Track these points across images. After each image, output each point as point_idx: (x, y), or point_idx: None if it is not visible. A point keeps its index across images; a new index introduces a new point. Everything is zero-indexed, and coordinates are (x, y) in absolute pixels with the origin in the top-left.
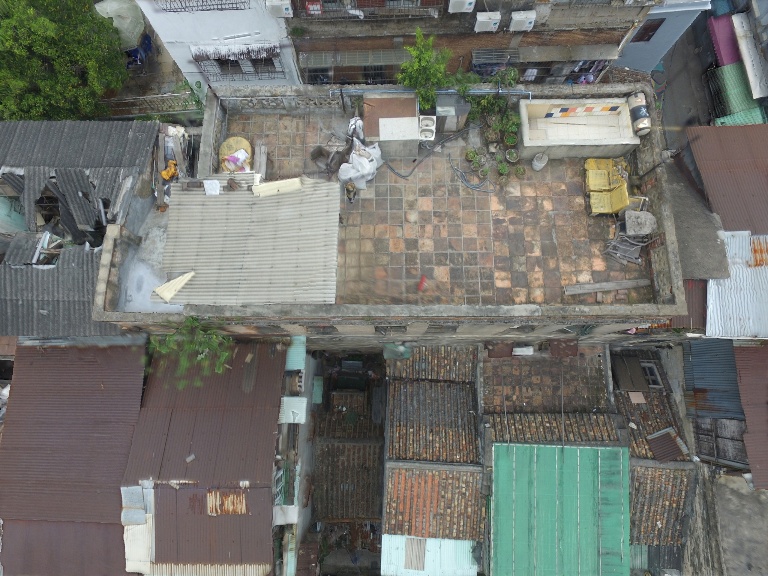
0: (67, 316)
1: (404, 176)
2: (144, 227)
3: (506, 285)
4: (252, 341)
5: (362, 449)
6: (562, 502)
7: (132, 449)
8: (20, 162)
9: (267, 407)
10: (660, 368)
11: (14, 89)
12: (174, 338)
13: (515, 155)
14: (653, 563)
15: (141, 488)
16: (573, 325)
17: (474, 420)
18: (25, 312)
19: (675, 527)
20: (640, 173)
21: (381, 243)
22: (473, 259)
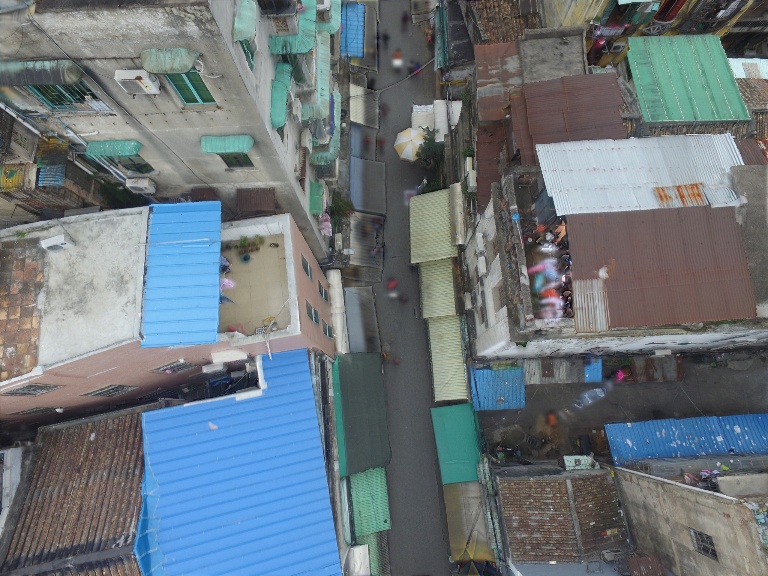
0: None
1: None
2: None
3: None
4: None
5: None
6: (686, 89)
7: None
8: None
9: None
10: None
11: None
12: None
13: None
14: None
15: None
16: None
17: None
18: None
19: None
20: None
21: None
22: None
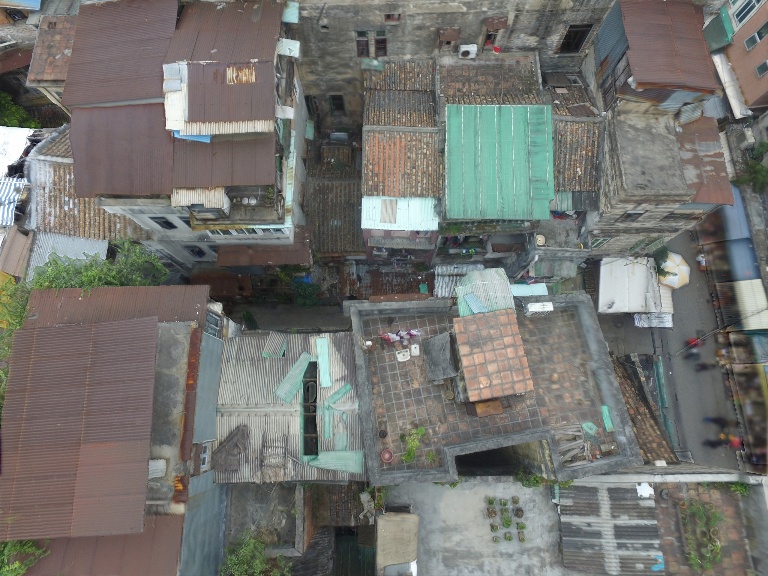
0: None
1: None
2: None
3: None
4: None
5: (348, 187)
6: (500, 145)
7: (170, 47)
8: None
9: (270, 27)
10: (581, 78)
11: None
12: None
13: None
14: (577, 206)
15: (178, 65)
16: None
17: (433, 107)
18: None
19: (592, 174)
20: None
21: None
22: None
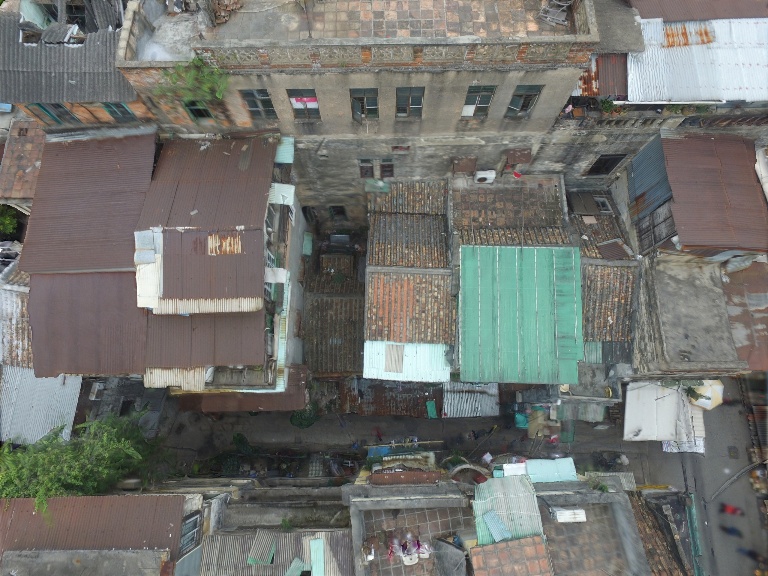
0: (92, 85)
1: None
2: (157, 22)
3: None
4: (247, 138)
5: (349, 303)
6: (522, 294)
7: (144, 207)
8: None
9: (260, 178)
10: (611, 201)
11: None
12: (183, 66)
13: None
14: (607, 358)
15: (152, 232)
16: (517, 96)
17: (445, 239)
18: (57, 82)
19: (625, 323)
20: None
21: (354, 14)
22: (429, 24)
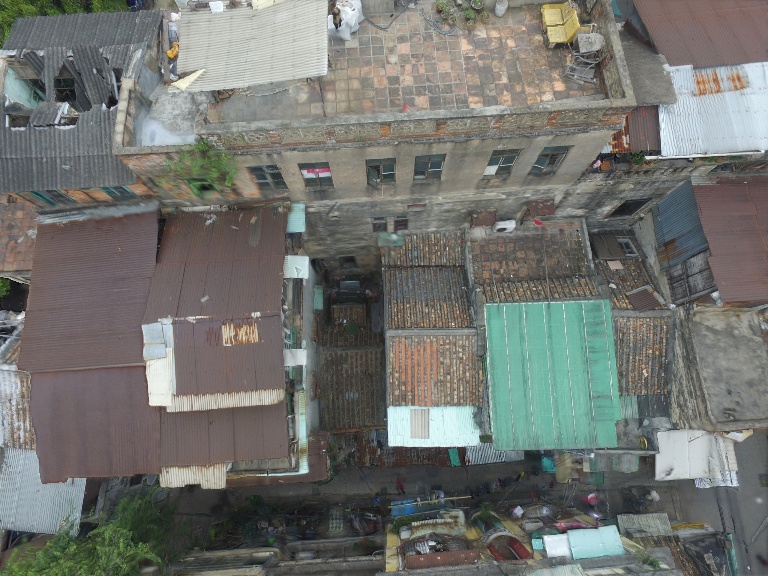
0: (87, 169)
1: (383, 28)
2: (154, 95)
3: (479, 107)
4: (255, 208)
5: (364, 356)
6: (552, 353)
7: (150, 295)
8: (39, 46)
9: (273, 255)
10: (635, 242)
11: (26, 14)
12: (188, 154)
13: (479, 4)
14: (643, 412)
15: (161, 324)
16: (544, 156)
17: (466, 294)
18: (49, 168)
19: (660, 375)
20: (589, 11)
21: (367, 81)
22: (449, 88)
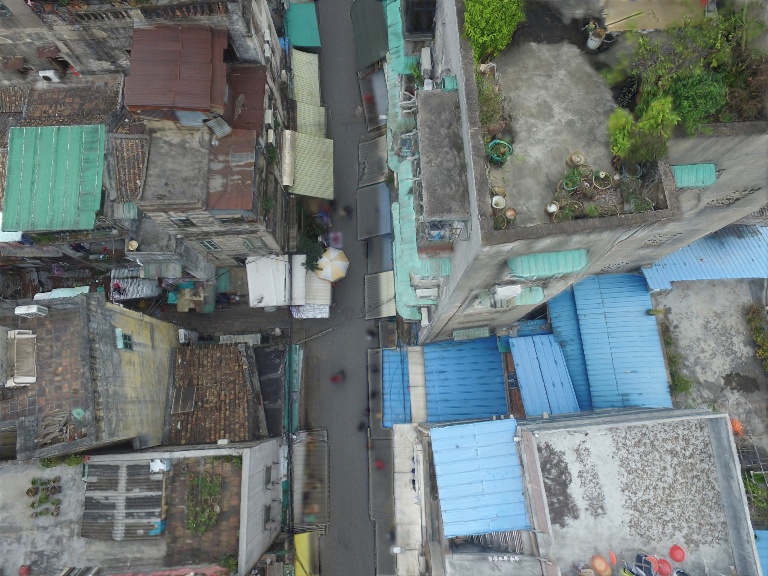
0: None
1: None
2: None
3: None
4: None
5: None
6: (56, 163)
7: None
8: None
9: None
10: None
11: None
12: None
13: None
14: (142, 214)
15: None
16: None
17: None
18: None
19: None
20: None
21: None
22: None
